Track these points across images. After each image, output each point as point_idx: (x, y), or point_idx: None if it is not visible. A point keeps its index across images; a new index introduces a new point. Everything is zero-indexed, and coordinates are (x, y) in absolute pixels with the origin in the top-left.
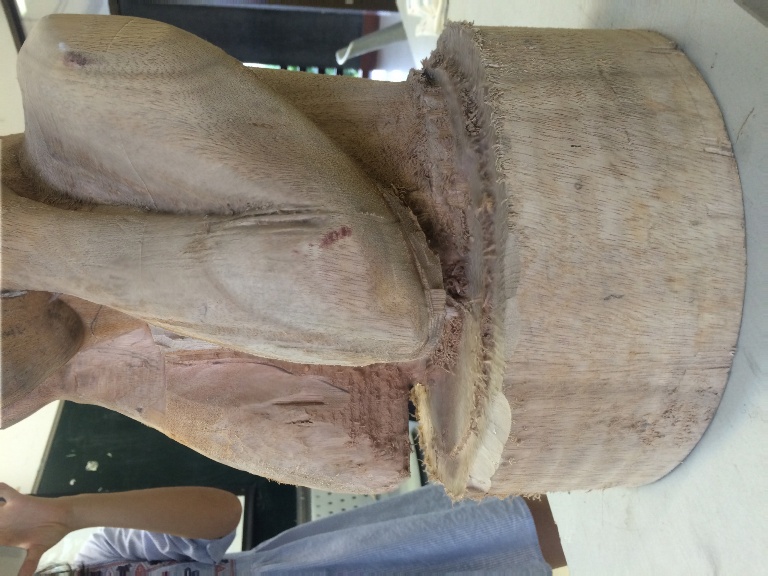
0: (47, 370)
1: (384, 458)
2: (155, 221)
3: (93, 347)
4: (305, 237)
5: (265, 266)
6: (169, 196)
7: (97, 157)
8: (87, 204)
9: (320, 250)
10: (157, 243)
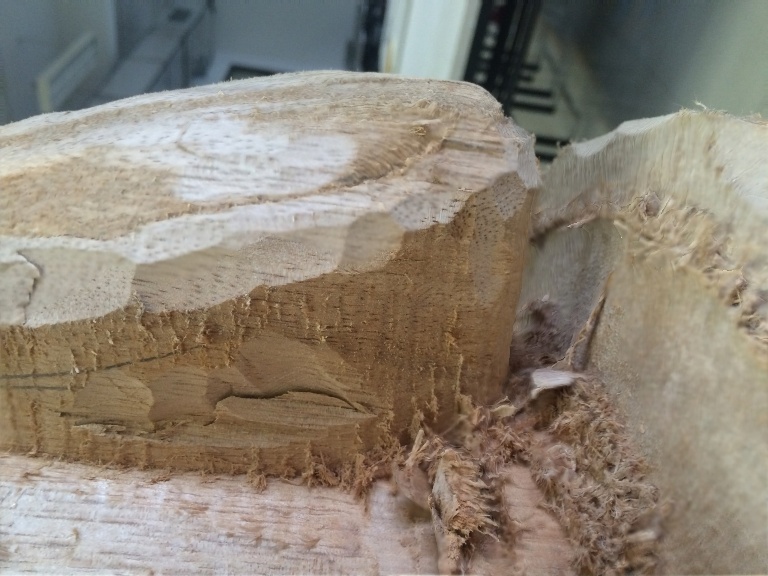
0: None
1: None
2: None
3: None
4: None
5: None
6: None
7: None
8: None
9: None
10: None
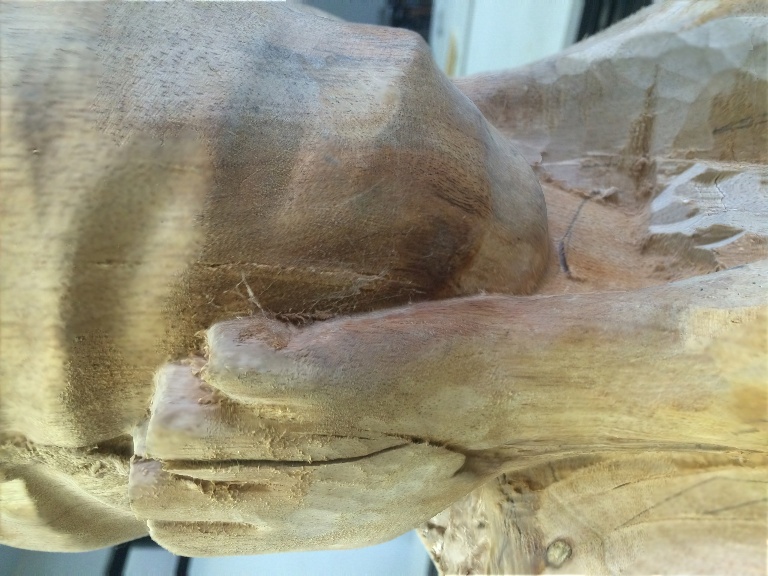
0: (514, 189)
1: None
2: None
3: None
4: None
5: None
6: None
7: None
8: None
9: None
10: None
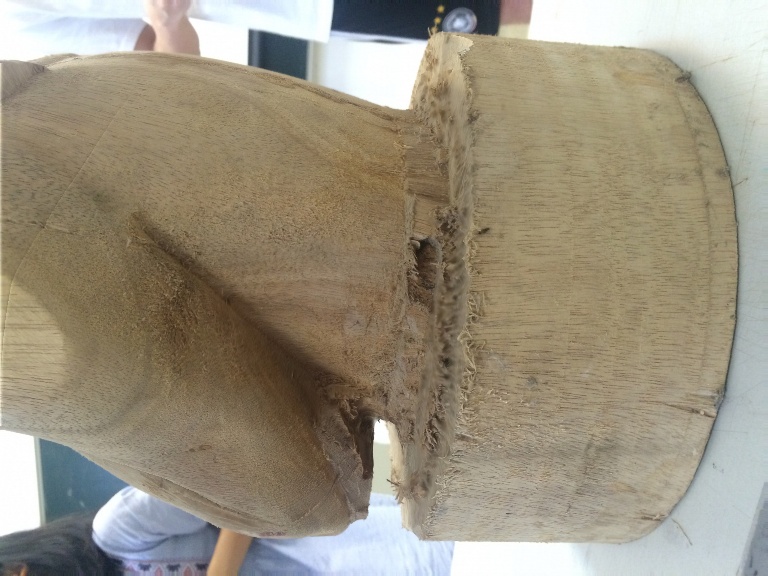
0: None
1: None
2: None
3: None
4: (246, 529)
5: None
6: None
7: None
8: None
9: None
10: None
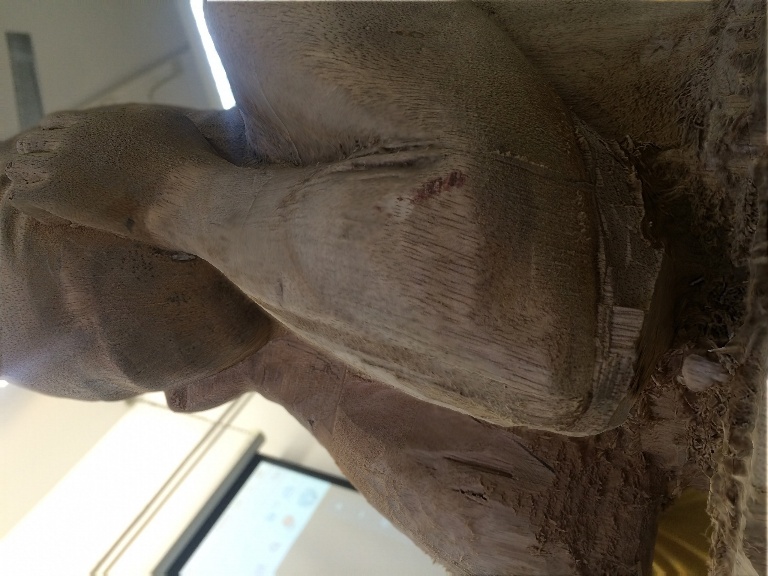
0: (222, 351)
1: None
2: (281, 173)
3: (284, 338)
4: (396, 186)
5: (340, 229)
6: (301, 141)
7: (251, 97)
8: (265, 163)
9: (410, 207)
10: (265, 197)
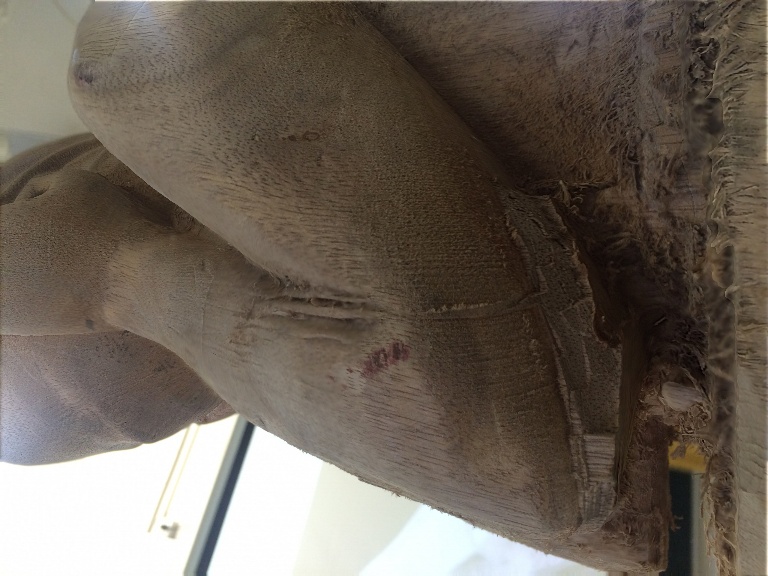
0: None
1: (617, 542)
2: (220, 276)
3: None
4: (342, 354)
5: (300, 390)
6: None
7: None
8: (198, 223)
9: (362, 381)
10: (213, 316)
